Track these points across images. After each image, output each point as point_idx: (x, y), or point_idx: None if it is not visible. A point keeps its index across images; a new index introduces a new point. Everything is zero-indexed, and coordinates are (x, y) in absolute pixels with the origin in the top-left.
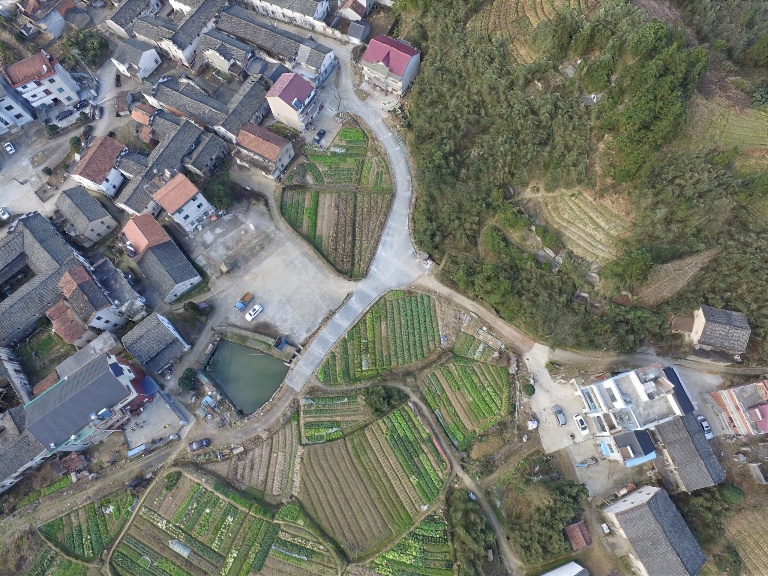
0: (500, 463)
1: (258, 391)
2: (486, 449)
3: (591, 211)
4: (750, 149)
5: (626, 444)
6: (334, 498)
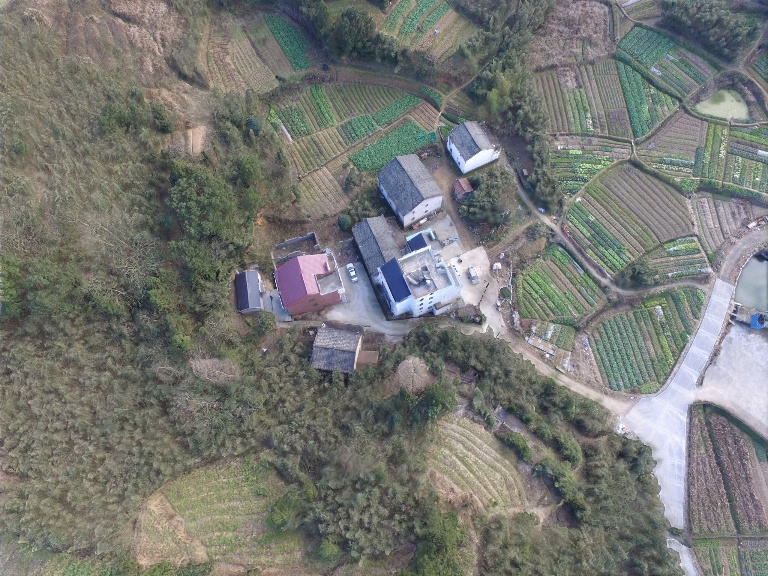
0: (522, 235)
1: (756, 277)
2: (534, 245)
3: (473, 480)
4: (283, 575)
5: (434, 242)
6: (655, 199)
